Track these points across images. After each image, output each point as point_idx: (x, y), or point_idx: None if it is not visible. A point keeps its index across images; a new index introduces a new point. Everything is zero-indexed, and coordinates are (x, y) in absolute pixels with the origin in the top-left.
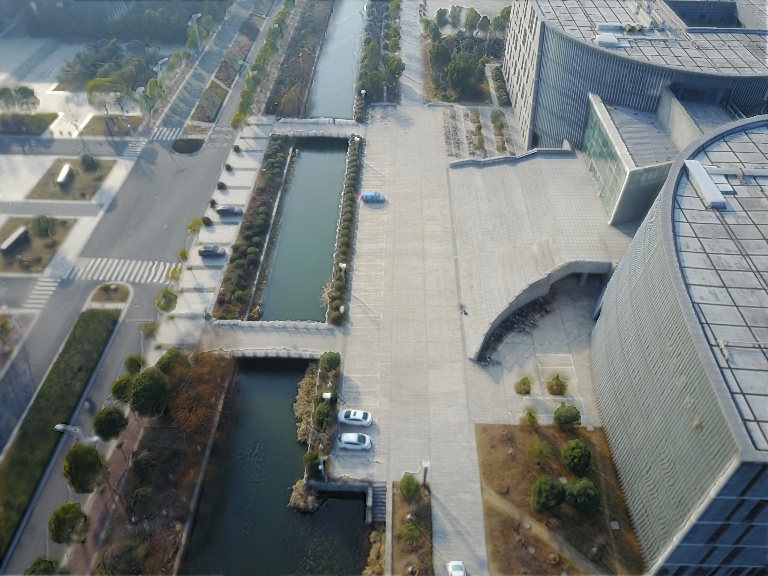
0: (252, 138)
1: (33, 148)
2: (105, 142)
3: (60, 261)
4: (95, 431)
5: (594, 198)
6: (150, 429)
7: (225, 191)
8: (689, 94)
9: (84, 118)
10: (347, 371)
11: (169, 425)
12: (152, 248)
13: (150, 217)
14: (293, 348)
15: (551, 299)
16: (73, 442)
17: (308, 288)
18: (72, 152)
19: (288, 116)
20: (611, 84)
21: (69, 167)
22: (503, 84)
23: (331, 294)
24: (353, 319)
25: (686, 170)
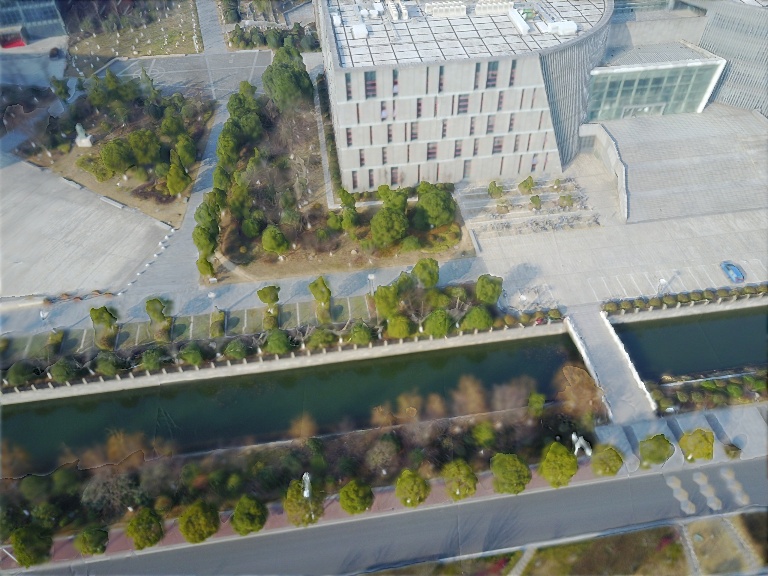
0: None
1: None
2: None
3: None
4: None
5: (667, 117)
6: None
7: None
8: None
9: None
10: None
11: None
12: None
13: None
14: None
15: None
16: None
17: None
18: None
19: None
20: None
21: None
22: None
23: None
24: None
25: None
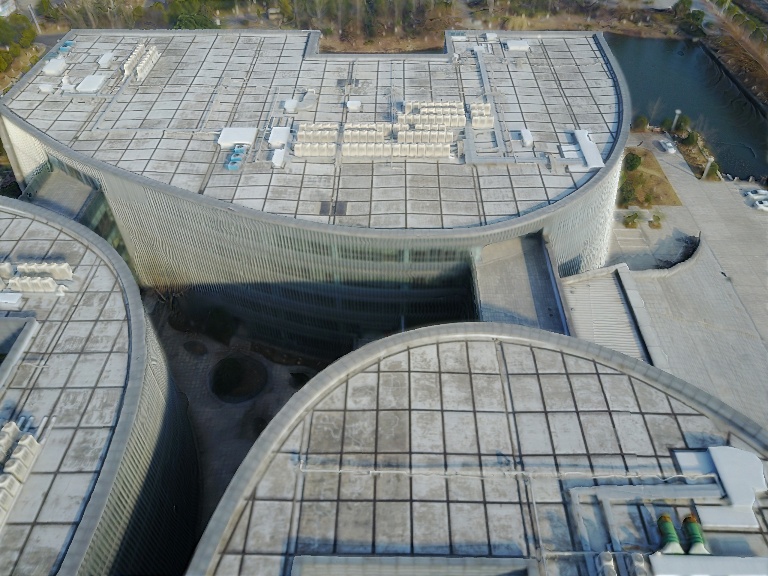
0: None
1: None
2: None
3: None
4: None
5: None
6: None
7: None
8: None
9: None
10: None
11: None
12: None
13: None
14: None
15: None
16: None
17: None
18: None
19: None
20: None
21: None
22: None
23: None
24: None
25: None
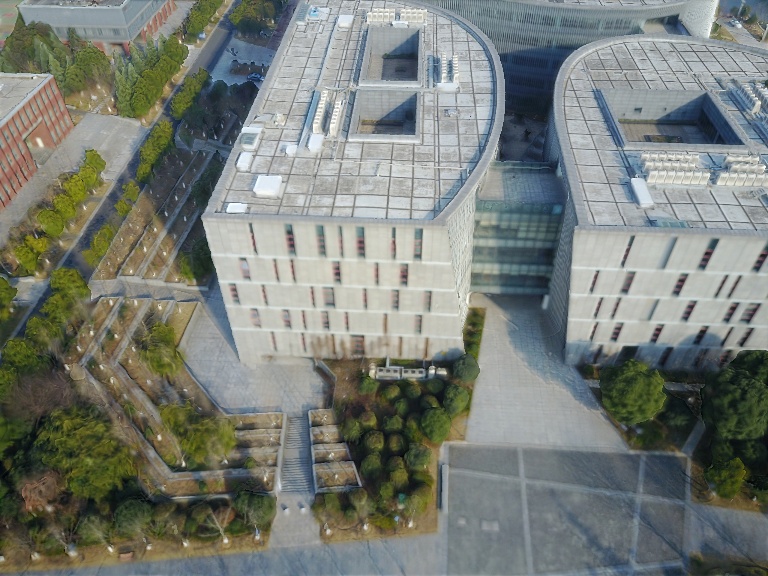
0: None
1: None
2: None
3: None
4: None
5: None
6: None
7: None
8: None
9: None
10: None
11: None
12: None
13: None
14: None
15: None
16: None
17: None
18: None
19: None
20: None
21: None
22: None
23: None
24: None
25: None
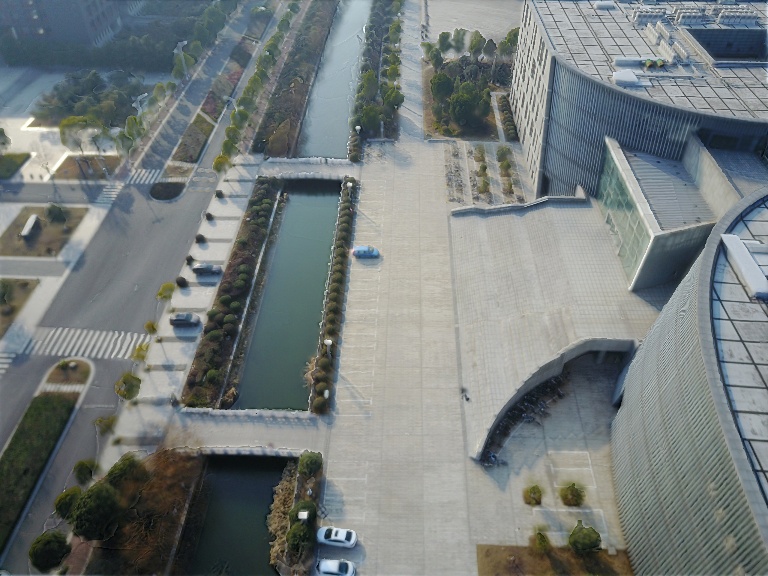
0: (237, 181)
1: (0, 194)
2: (78, 186)
3: (17, 331)
4: (31, 562)
5: (612, 257)
6: (100, 551)
7: (204, 245)
8: (719, 141)
9: (58, 159)
10: (330, 473)
11: (121, 546)
12: (119, 315)
13: (120, 277)
14: (269, 443)
15: (564, 380)
16: (9, 569)
17: (291, 363)
18: (42, 199)
19: (277, 155)
20: (630, 128)
21: (36, 217)
22: (510, 115)
23: (315, 374)
24: (339, 405)
25: (724, 248)
